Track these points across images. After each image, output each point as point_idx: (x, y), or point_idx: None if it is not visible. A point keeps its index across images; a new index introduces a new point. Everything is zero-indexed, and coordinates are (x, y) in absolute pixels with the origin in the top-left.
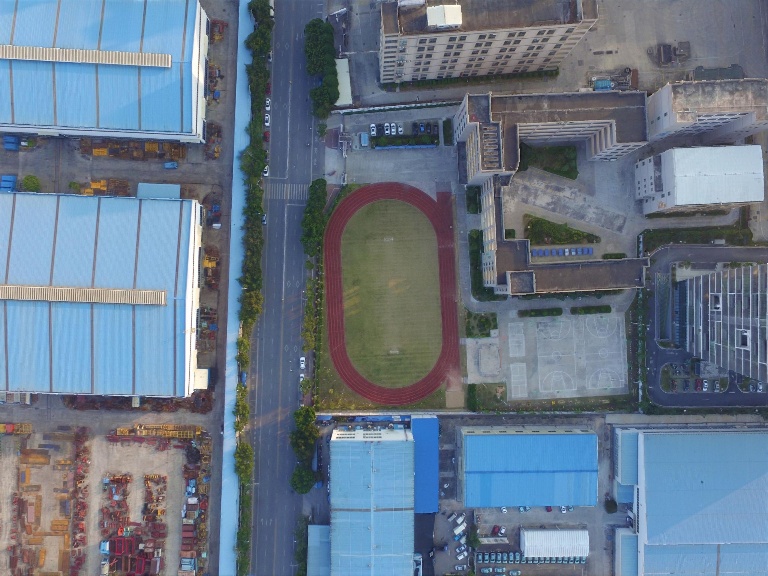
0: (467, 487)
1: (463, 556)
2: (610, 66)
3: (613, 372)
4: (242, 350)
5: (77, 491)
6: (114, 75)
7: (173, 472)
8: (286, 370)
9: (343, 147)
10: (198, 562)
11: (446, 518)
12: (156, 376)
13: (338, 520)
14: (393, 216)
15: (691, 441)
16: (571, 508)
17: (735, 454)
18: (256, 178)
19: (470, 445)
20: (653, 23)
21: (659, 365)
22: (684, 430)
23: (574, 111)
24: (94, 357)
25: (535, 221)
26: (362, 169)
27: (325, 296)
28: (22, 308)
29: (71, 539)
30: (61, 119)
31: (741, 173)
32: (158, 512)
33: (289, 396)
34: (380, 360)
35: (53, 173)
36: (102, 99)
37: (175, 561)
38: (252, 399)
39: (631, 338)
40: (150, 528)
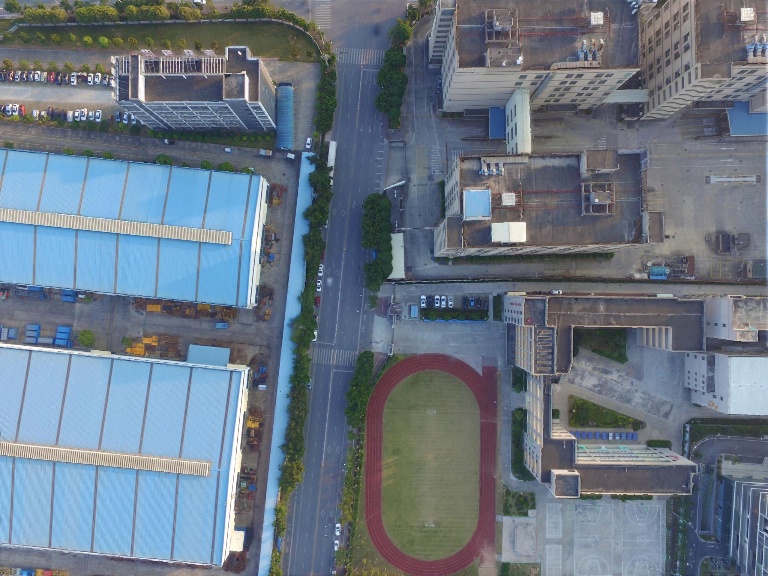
0: None
1: None
2: (666, 251)
3: (650, 560)
4: (280, 517)
5: None
6: (175, 248)
7: None
8: (321, 535)
9: (393, 320)
10: None
11: None
12: (195, 544)
13: None
14: (437, 388)
15: None
16: None
17: None
18: (305, 348)
19: None
20: (713, 209)
21: (698, 558)
22: None
23: (630, 315)
24: (136, 521)
25: (580, 403)
26: (409, 339)
27: (364, 464)
28: (70, 470)
29: None
30: (121, 287)
31: None
32: None
33: (322, 561)
34: (415, 531)
35: (107, 326)
36: (162, 270)
37: None
38: (285, 561)
39: (671, 528)
40: None
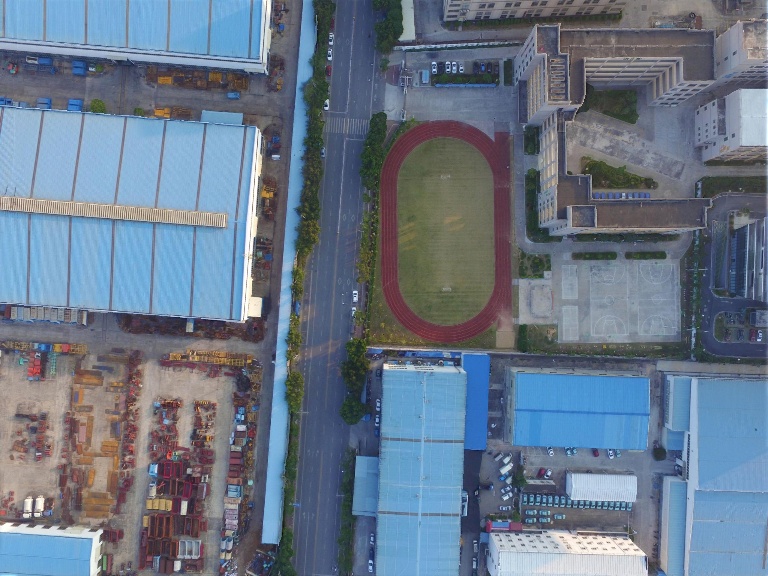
0: (517, 425)
1: (508, 497)
2: (674, 12)
3: (666, 319)
4: (297, 279)
5: (128, 413)
6: None
7: (223, 399)
8: (338, 303)
9: (404, 82)
10: (244, 490)
11: (492, 458)
12: (213, 299)
13: (388, 449)
14: (450, 154)
15: (746, 388)
16: (619, 454)
17: None
18: (318, 109)
19: (521, 383)
20: None
21: (713, 313)
22: (738, 379)
23: (642, 47)
24: (154, 277)
25: (593, 164)
26: (421, 106)
27: (380, 231)
28: (86, 225)
29: (120, 461)
30: (132, 41)
31: None
32: (207, 438)
33: (340, 329)
34: (432, 297)
35: (118, 99)
36: (173, 23)
37: (221, 488)
38: (304, 330)
39: (685, 285)
40: (198, 454)
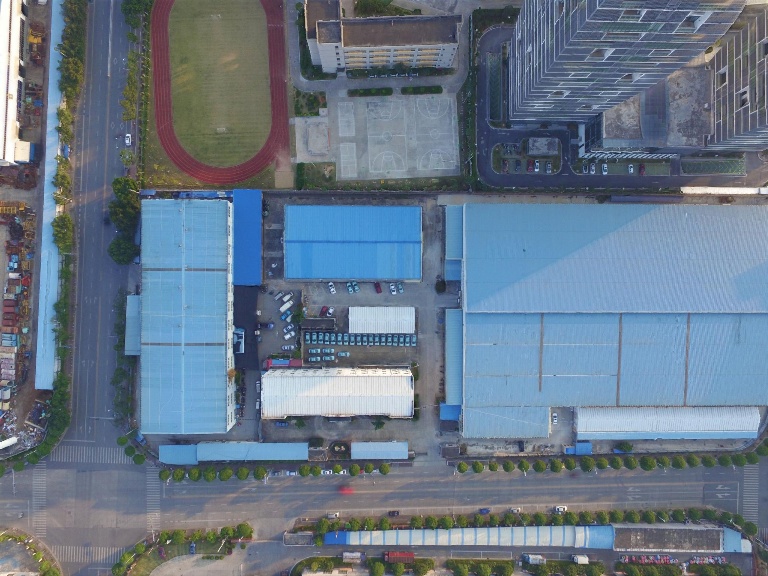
0: (287, 257)
1: (290, 335)
2: None
3: (444, 153)
4: (62, 120)
5: None
6: None
7: None
8: (112, 147)
9: None
10: (20, 339)
11: (273, 298)
12: None
13: (149, 280)
14: None
15: (514, 210)
16: (401, 289)
17: (559, 224)
18: None
19: (291, 215)
20: None
21: (490, 145)
22: None
23: None
24: None
25: None
26: None
27: (152, 74)
28: None
29: None
30: None
31: None
32: None
33: (115, 173)
34: (208, 139)
35: None
36: None
37: None
38: (77, 176)
39: (462, 118)
40: None
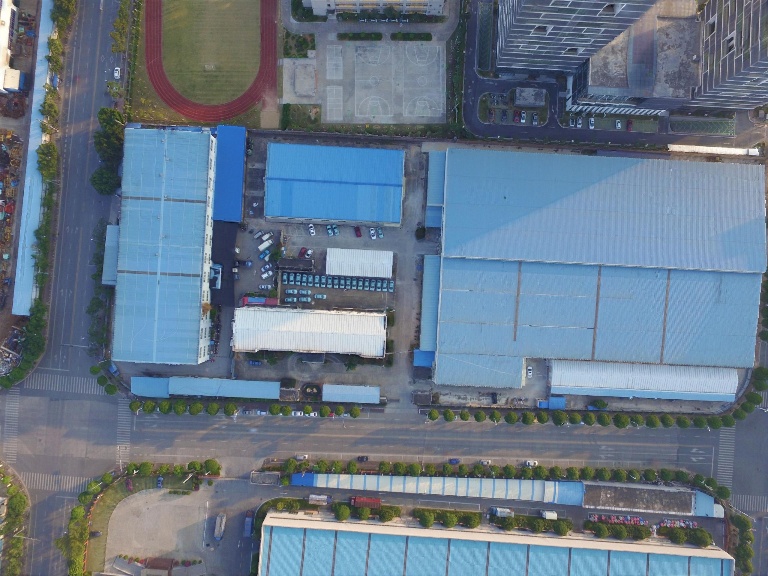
0: (268, 194)
1: (267, 274)
2: None
3: (431, 101)
4: (52, 49)
5: None
6: None
7: None
8: (101, 80)
9: None
10: (1, 265)
11: (253, 236)
12: None
13: (128, 208)
14: None
15: (497, 157)
16: (381, 234)
17: (541, 173)
18: None
19: (273, 152)
20: None
21: (477, 95)
22: None
23: None
24: None
25: None
26: None
27: (144, 9)
28: None
29: None
30: None
31: None
32: None
33: (102, 106)
34: (196, 76)
35: None
36: None
37: None
38: (65, 107)
39: (451, 67)
40: None
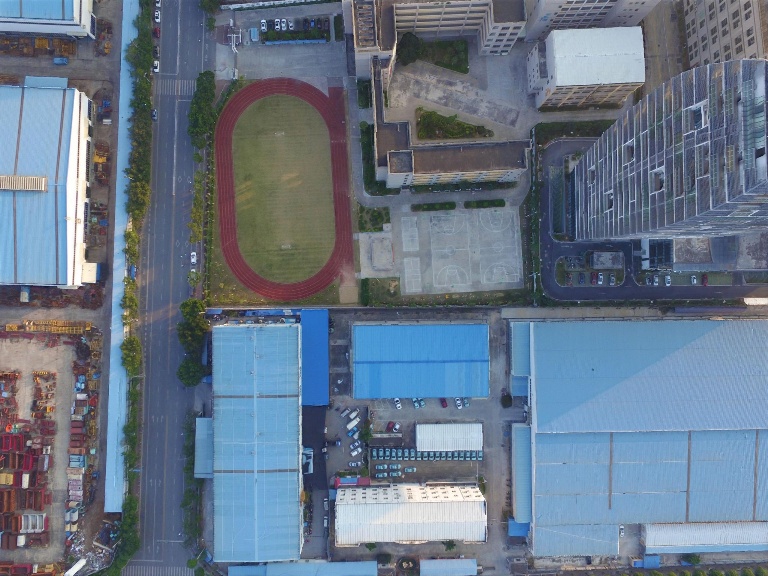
0: (356, 378)
1: (357, 452)
2: None
3: (508, 266)
4: (129, 242)
5: None
6: None
7: (63, 369)
8: (177, 266)
9: (232, 41)
10: (88, 460)
11: (340, 414)
12: (38, 264)
13: (221, 407)
14: (285, 111)
15: (582, 329)
16: (467, 404)
17: (626, 342)
18: (143, 70)
19: (359, 335)
20: None
21: (554, 258)
22: (577, 321)
23: None
24: None
25: (427, 115)
26: (253, 65)
27: (216, 191)
28: None
29: None
30: None
31: (621, 54)
32: (47, 409)
33: (180, 292)
34: (272, 255)
35: None
36: None
37: (64, 459)
38: (143, 295)
39: (525, 232)
40: (39, 425)
